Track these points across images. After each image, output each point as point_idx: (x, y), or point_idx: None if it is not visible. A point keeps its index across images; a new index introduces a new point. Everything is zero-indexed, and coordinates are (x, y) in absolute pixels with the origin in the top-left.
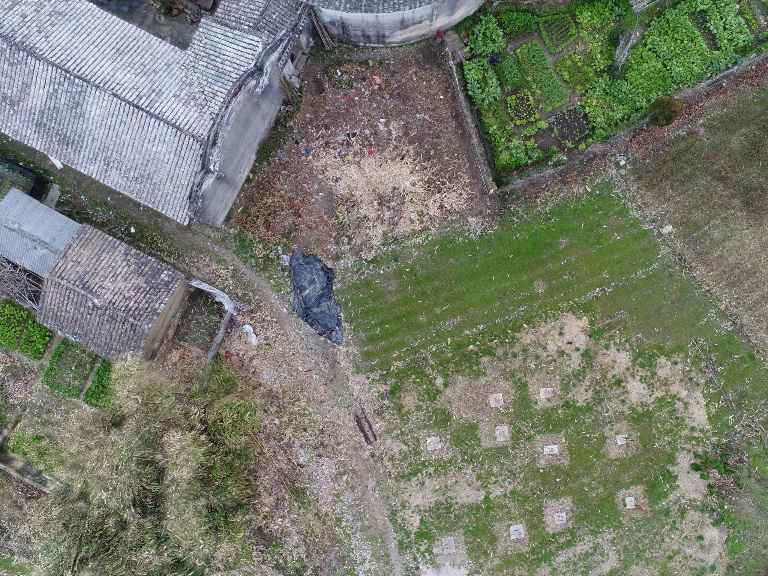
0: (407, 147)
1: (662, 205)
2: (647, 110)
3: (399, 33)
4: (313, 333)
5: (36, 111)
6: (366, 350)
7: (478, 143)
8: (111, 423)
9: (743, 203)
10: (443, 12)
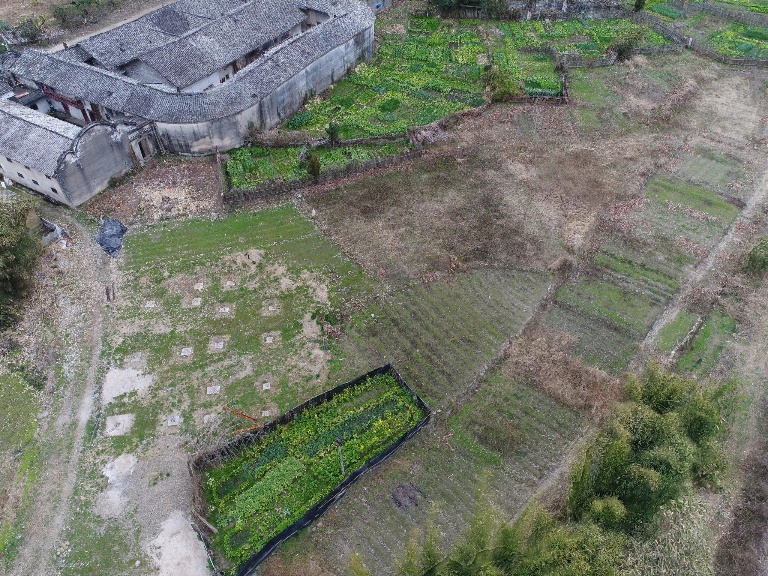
0: (189, 187)
1: (319, 213)
2: None
3: (196, 144)
4: (101, 249)
5: (6, 138)
6: (129, 261)
7: (226, 187)
8: None
9: (362, 213)
10: (215, 134)
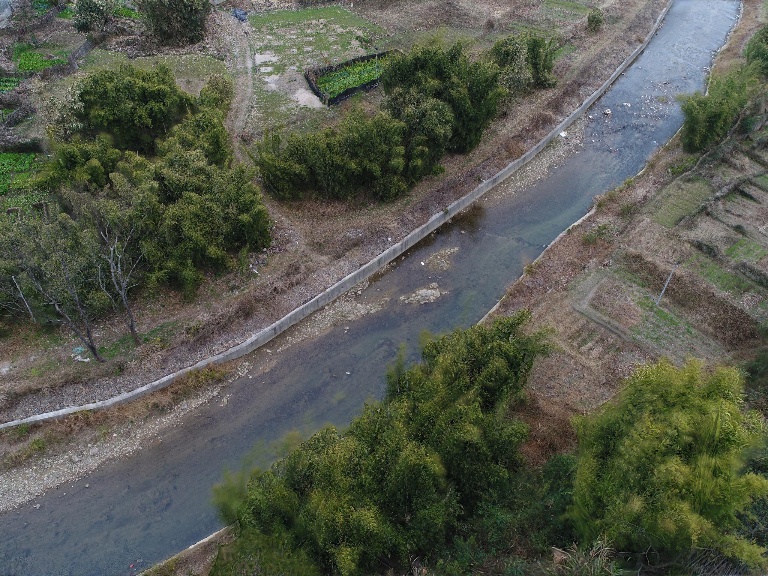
0: None
1: None
2: None
3: None
4: None
5: None
6: None
7: None
8: None
9: (379, 8)
10: None
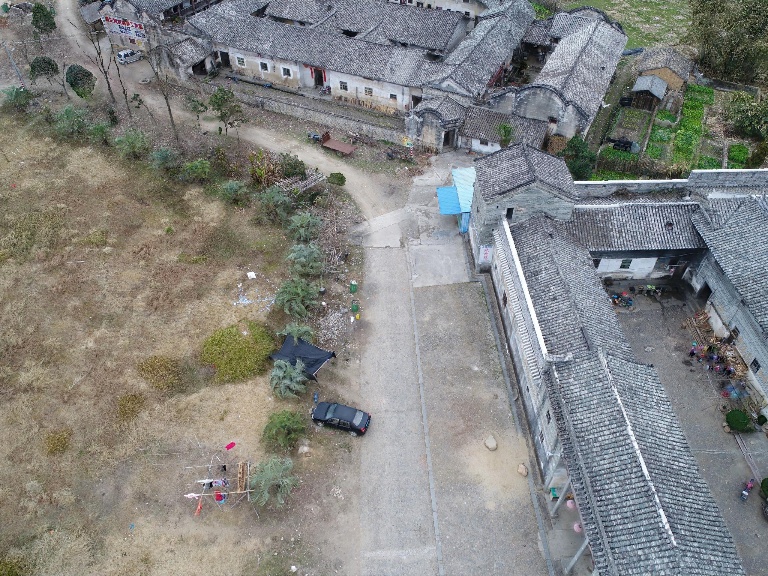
0: None
1: None
2: (530, 2)
3: None
4: None
5: None
6: None
7: None
8: (717, 80)
9: None
10: None
